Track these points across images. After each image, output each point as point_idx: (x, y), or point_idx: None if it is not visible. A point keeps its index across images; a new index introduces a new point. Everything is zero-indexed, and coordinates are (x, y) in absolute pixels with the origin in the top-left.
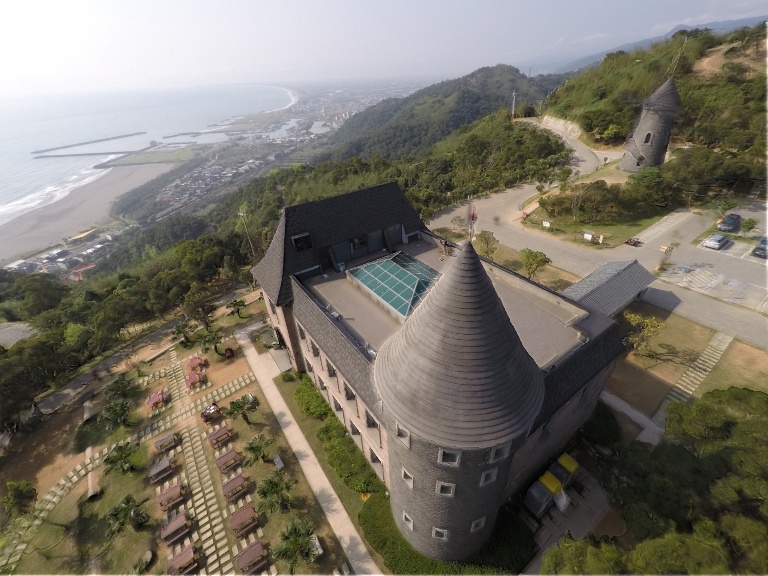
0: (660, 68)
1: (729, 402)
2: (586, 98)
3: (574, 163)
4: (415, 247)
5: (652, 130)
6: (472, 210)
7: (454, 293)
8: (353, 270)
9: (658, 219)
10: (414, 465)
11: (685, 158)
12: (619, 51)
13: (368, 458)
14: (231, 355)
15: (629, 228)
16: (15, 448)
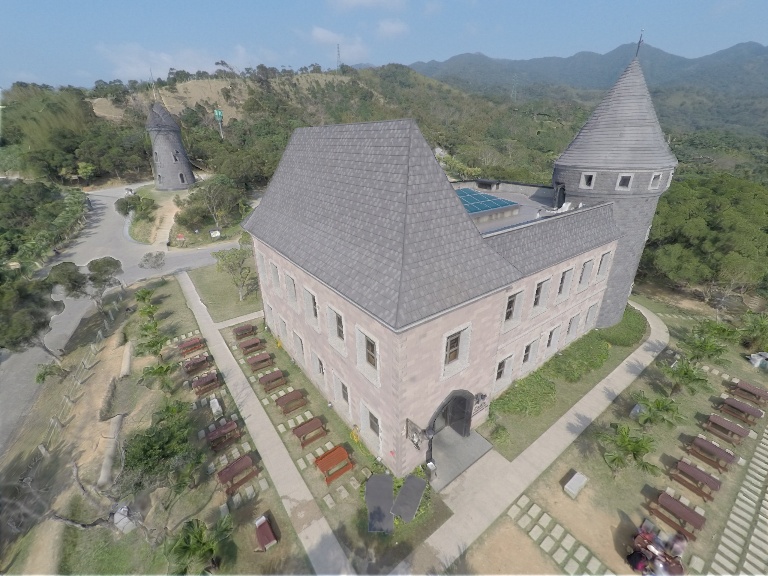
0: (65, 110)
1: None
2: None
3: None
4: None
5: None
6: None
7: None
8: None
9: None
10: None
11: None
12: None
13: None
14: None
15: None
16: None
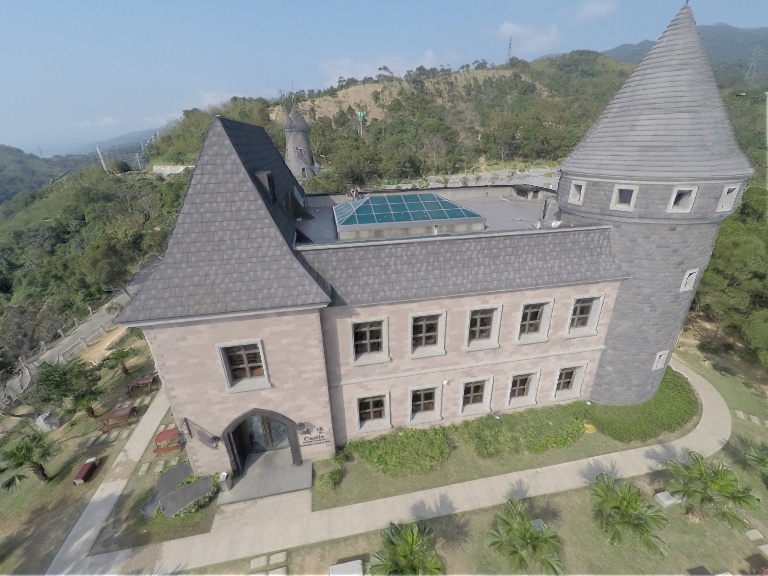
0: (249, 116)
1: None
2: (193, 145)
3: None
4: (321, 211)
5: (301, 147)
6: None
7: None
8: (347, 221)
9: None
10: (706, 248)
11: (341, 159)
12: (194, 108)
13: (545, 403)
14: None
15: None
16: None
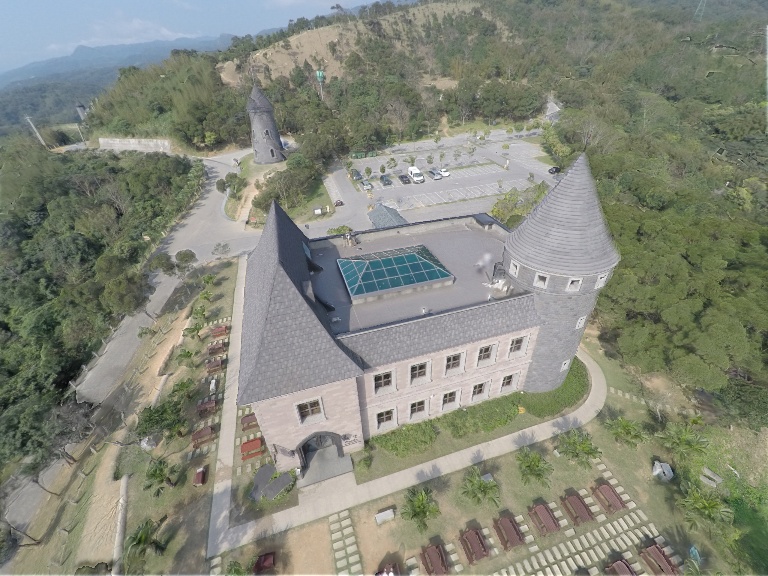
0: (200, 82)
1: (513, 225)
2: (142, 114)
3: (209, 171)
4: (324, 256)
5: (267, 128)
6: (189, 242)
7: (593, 182)
8: (357, 290)
9: (324, 187)
10: None
11: (310, 142)
12: (133, 67)
13: (494, 396)
14: (273, 555)
15: (321, 198)
16: None
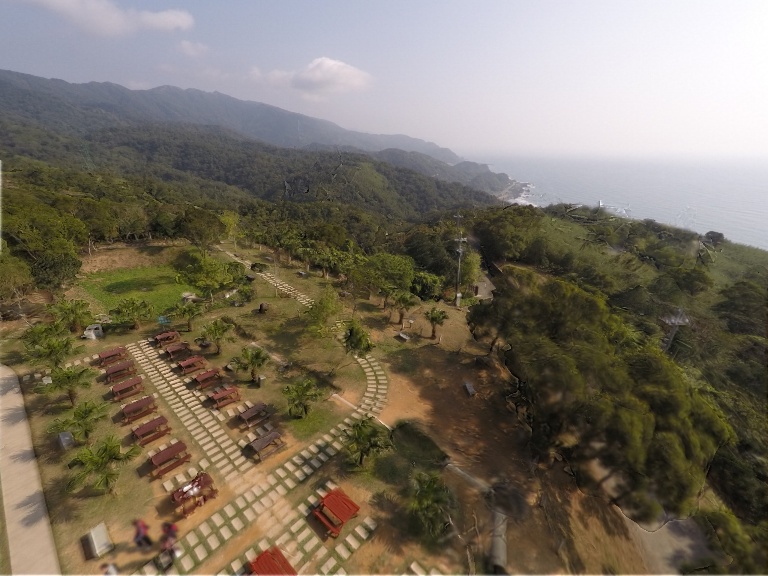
0: None
1: None
2: None
3: None
4: None
5: None
6: None
7: None
8: None
9: None
10: None
11: None
12: None
13: None
14: None
15: None
16: (516, 431)
